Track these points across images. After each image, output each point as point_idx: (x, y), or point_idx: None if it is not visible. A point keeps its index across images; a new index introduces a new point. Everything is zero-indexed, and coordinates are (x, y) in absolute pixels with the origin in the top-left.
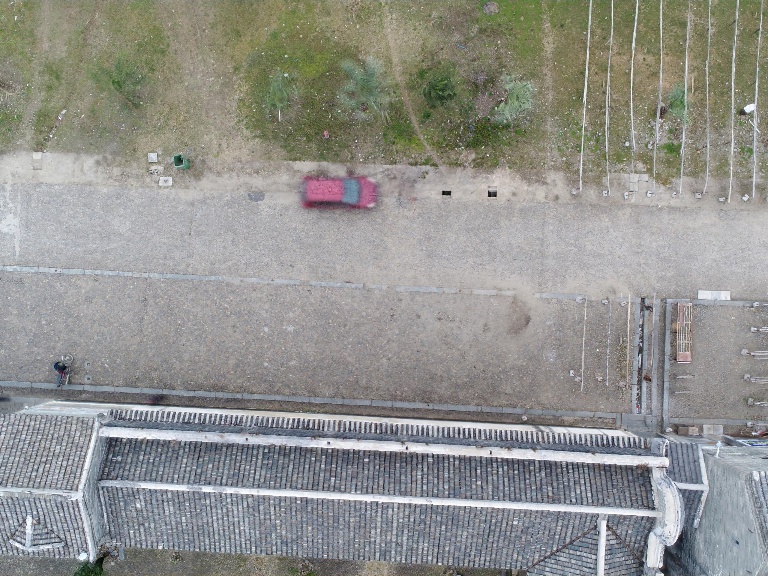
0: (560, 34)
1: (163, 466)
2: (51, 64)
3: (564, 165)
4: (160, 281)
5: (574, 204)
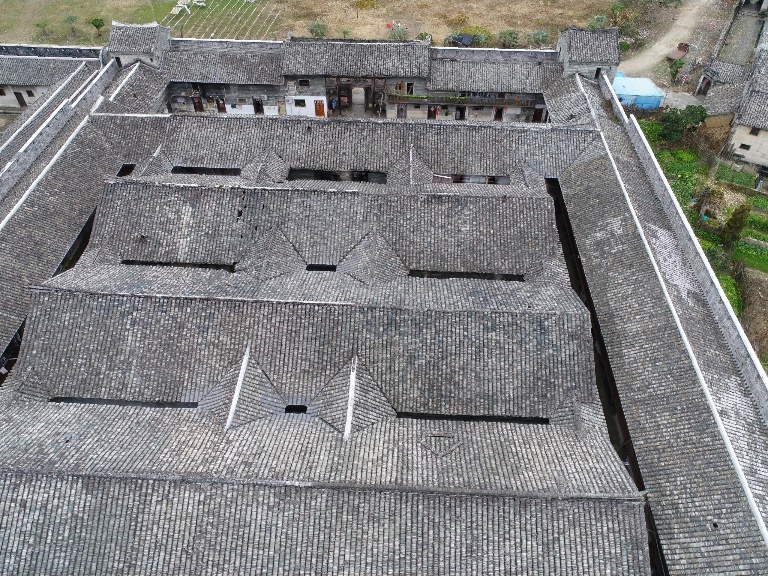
0: None
1: None
2: None
3: None
4: None
5: None
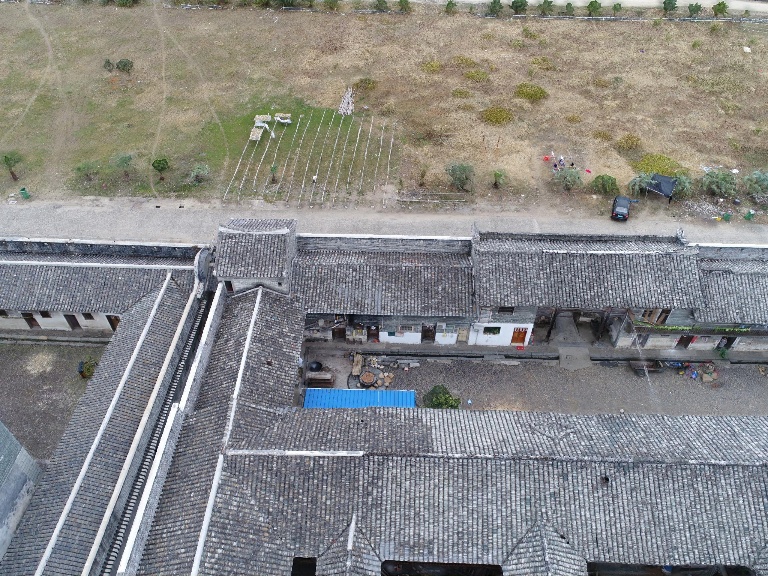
0: (232, 161)
1: None
2: None
3: (222, 197)
4: None
5: (223, 209)
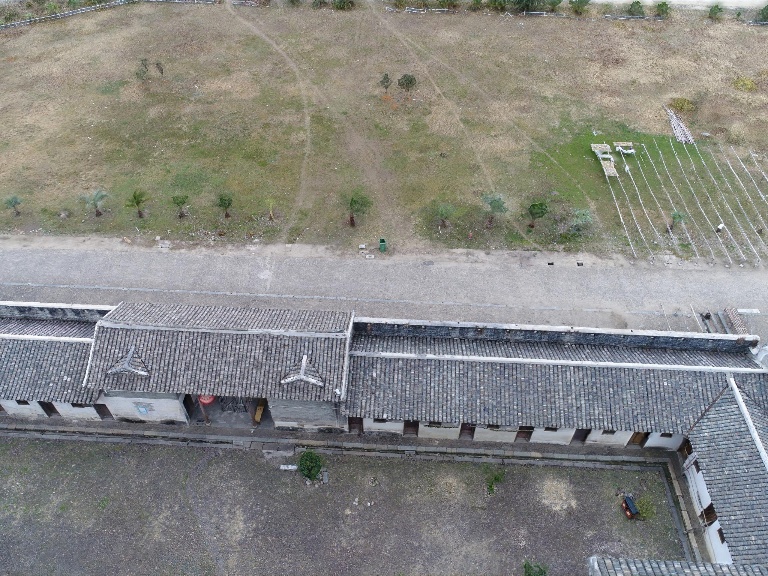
0: (597, 202)
1: (394, 349)
2: (303, 210)
3: (621, 251)
4: (365, 302)
5: (634, 268)
